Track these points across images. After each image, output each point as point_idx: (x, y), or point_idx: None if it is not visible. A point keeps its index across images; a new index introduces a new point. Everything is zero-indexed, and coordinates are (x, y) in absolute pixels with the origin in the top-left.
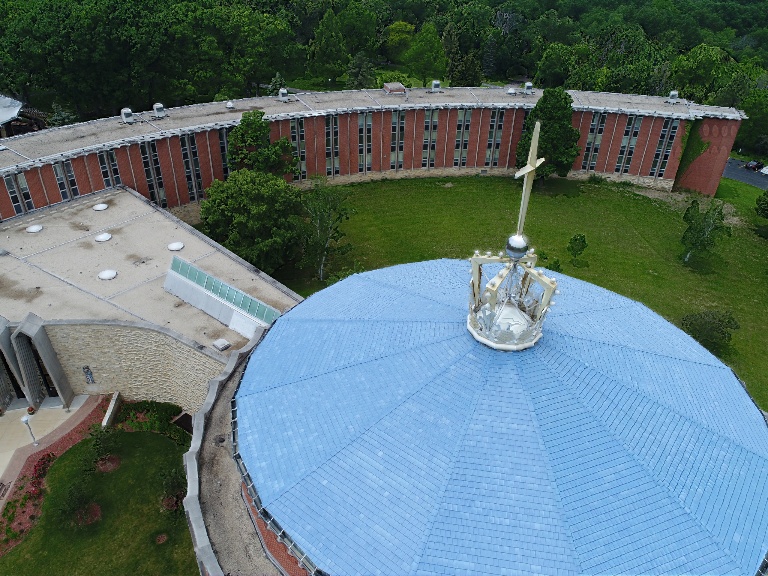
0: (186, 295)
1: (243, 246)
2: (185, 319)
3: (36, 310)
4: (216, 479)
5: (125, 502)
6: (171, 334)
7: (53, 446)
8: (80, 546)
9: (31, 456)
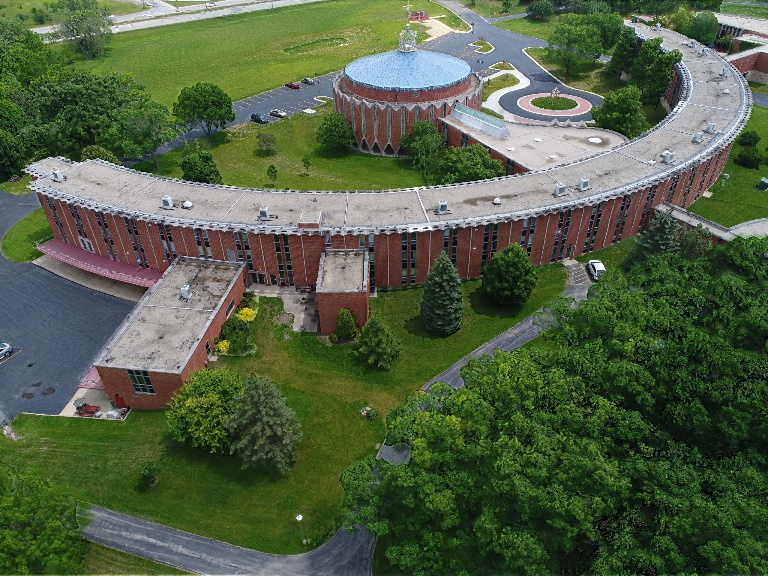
0: None
1: None
2: None
3: None
4: None
5: None
6: None
7: None
8: None
9: None
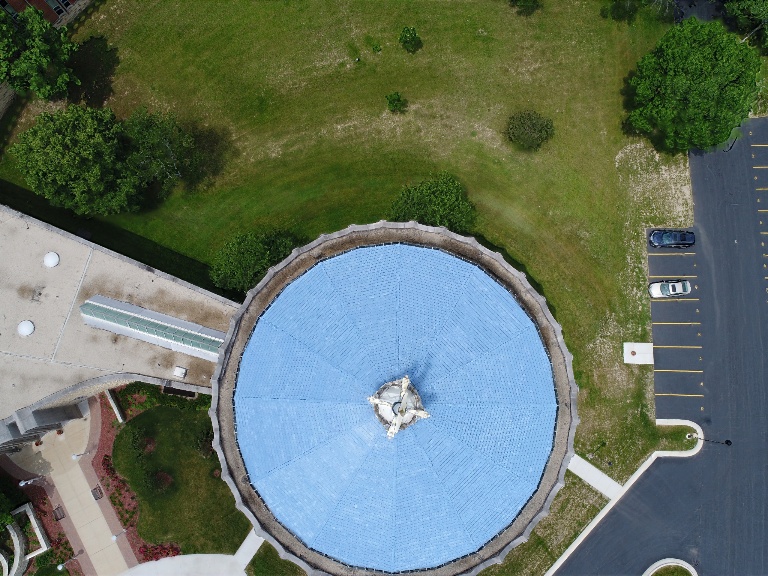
0: (115, 330)
1: (96, 199)
2: (133, 355)
3: (8, 395)
4: (261, 507)
5: (179, 463)
6: (137, 380)
7: (100, 449)
8: (175, 500)
9: (93, 462)
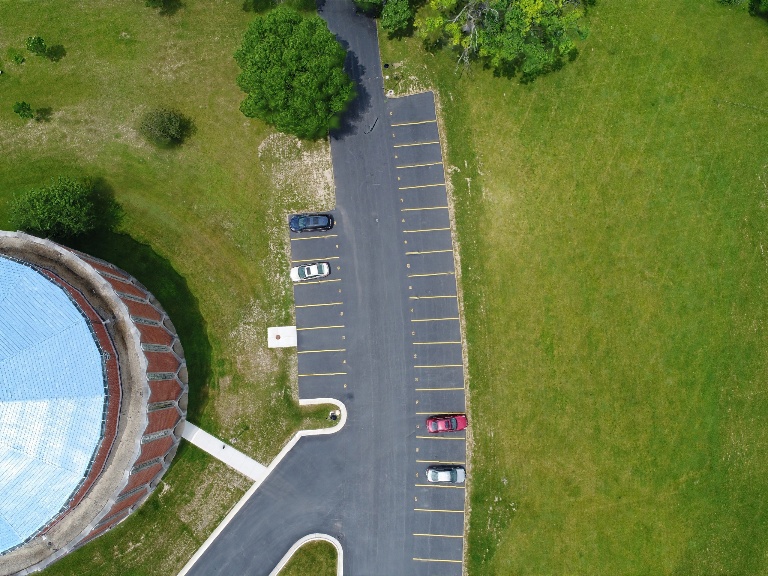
0: None
1: None
2: None
3: None
4: None
5: None
6: None
7: None
8: None
9: None
